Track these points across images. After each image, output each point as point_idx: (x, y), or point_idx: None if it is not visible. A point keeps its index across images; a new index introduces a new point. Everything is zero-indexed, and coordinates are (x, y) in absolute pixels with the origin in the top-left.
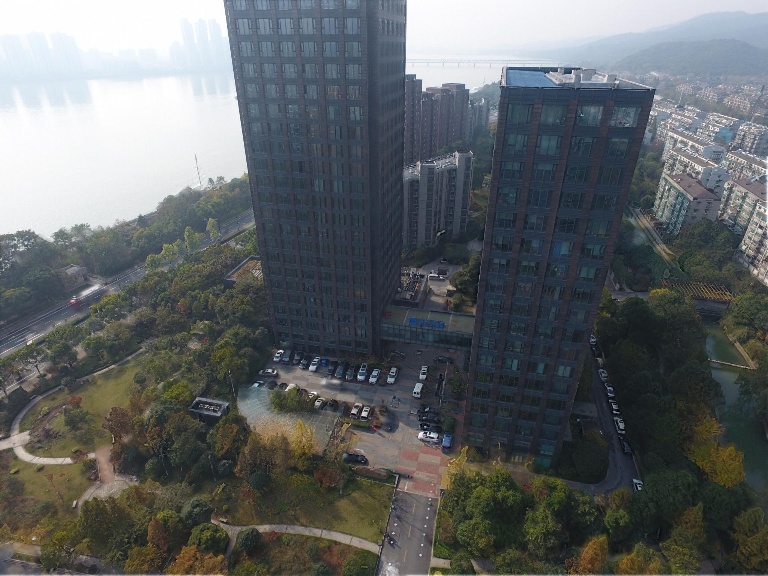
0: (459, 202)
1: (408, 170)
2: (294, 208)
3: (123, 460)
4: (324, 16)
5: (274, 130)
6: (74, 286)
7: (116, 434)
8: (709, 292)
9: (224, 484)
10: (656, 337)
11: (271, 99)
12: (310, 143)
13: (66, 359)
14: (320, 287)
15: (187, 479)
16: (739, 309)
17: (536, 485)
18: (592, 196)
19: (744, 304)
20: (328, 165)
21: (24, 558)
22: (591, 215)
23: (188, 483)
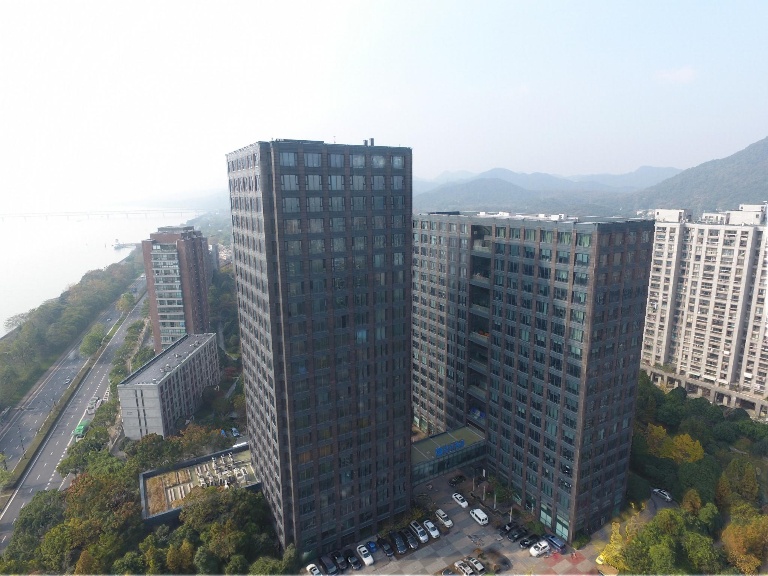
0: None
1: None
2: (334, 370)
3: None
4: (374, 174)
5: (316, 287)
6: None
7: None
8: None
9: None
10: None
11: (316, 255)
12: (355, 294)
13: None
14: (358, 454)
15: None
16: None
17: (663, 522)
18: None
19: None
20: (373, 313)
21: None
22: (635, 301)
23: None
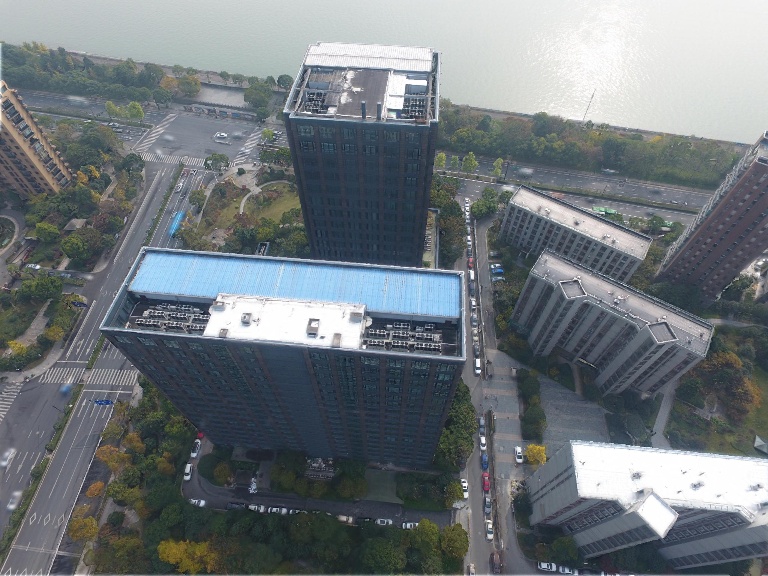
0: (618, 363)
1: (588, 277)
2: None
3: None
4: None
5: None
6: None
7: None
8: None
9: None
10: (346, 571)
11: None
12: None
13: None
14: None
15: None
16: None
17: None
18: None
19: None
20: None
21: None
22: None
23: None
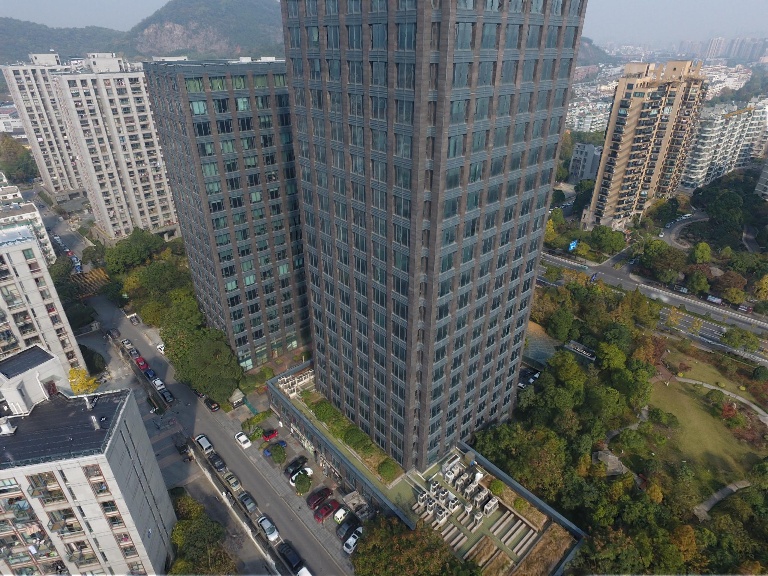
0: None
1: None
2: None
3: None
4: None
5: None
6: None
7: None
8: (94, 277)
9: None
10: None
11: None
12: None
13: None
14: None
15: None
16: (123, 263)
17: None
18: None
19: (125, 256)
20: None
21: (683, 338)
22: None
23: None
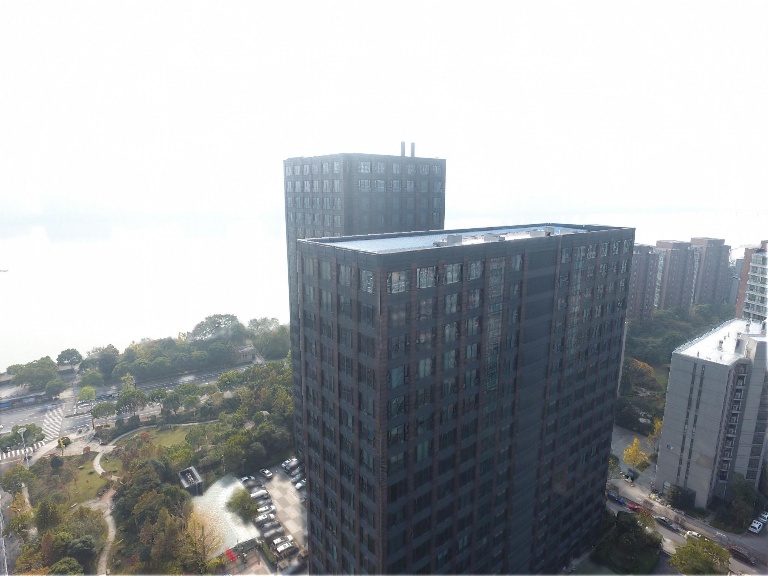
0: None
1: None
2: None
3: (117, 490)
4: (324, 179)
5: None
6: (243, 360)
7: (124, 467)
8: None
9: (122, 539)
10: None
11: None
12: None
13: (171, 406)
14: None
15: (124, 524)
16: None
17: None
18: (357, 364)
19: None
20: None
21: None
22: (360, 387)
23: (125, 529)
